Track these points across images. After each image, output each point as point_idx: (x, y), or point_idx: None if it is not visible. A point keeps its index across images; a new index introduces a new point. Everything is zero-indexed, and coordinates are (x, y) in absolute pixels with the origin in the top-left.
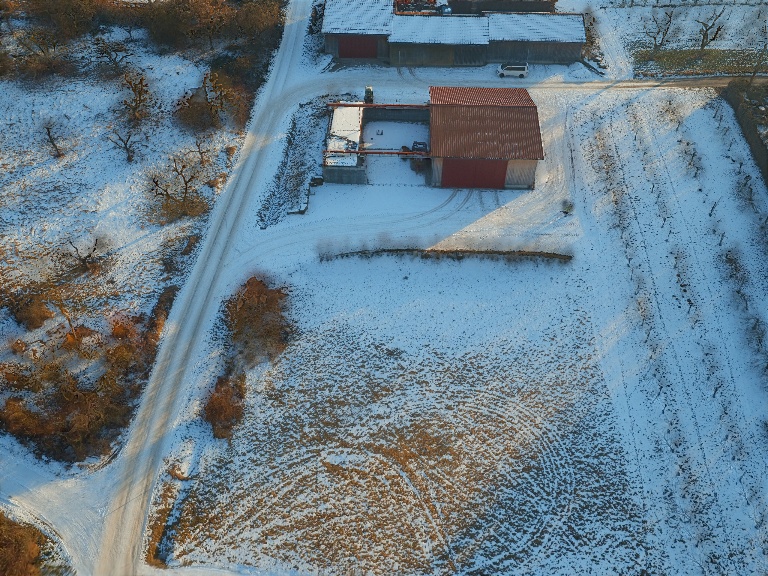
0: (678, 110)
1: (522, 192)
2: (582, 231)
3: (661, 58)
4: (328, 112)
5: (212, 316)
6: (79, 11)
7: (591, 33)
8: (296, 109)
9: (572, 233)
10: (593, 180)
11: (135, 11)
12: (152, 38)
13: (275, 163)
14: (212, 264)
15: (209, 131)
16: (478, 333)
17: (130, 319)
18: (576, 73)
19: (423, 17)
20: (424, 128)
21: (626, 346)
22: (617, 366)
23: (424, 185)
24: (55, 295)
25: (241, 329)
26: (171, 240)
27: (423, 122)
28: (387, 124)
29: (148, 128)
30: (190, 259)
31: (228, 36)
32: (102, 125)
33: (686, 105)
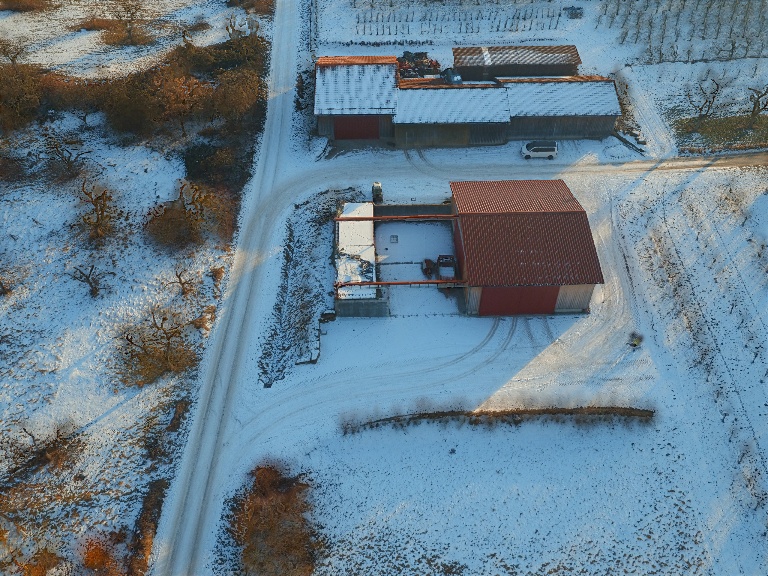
0: (739, 197)
1: (576, 318)
2: (657, 372)
3: (706, 129)
4: (331, 216)
5: (214, 525)
6: (22, 96)
7: (621, 99)
8: (291, 212)
9: (646, 375)
10: (658, 298)
11: (90, 91)
12: (112, 124)
13: (273, 289)
14: (208, 443)
15: (189, 248)
16: (554, 532)
17: (107, 537)
18: (613, 151)
19: (431, 90)
20: (446, 230)
21: (741, 543)
22: (736, 574)
23: (458, 314)
24: (7, 503)
25: (253, 543)
26: (153, 409)
27: (443, 222)
28: (401, 227)
29: (114, 248)
30: (179, 437)
31: (202, 117)
32: (57, 246)
33: (747, 190)
